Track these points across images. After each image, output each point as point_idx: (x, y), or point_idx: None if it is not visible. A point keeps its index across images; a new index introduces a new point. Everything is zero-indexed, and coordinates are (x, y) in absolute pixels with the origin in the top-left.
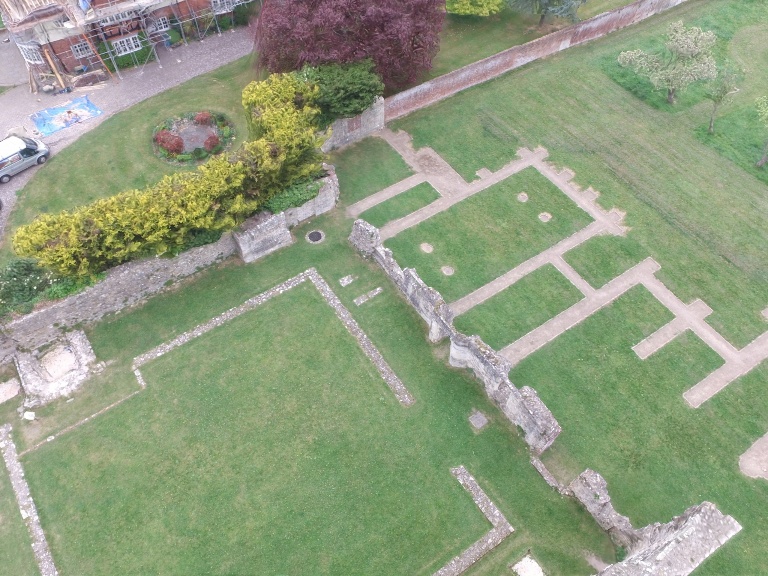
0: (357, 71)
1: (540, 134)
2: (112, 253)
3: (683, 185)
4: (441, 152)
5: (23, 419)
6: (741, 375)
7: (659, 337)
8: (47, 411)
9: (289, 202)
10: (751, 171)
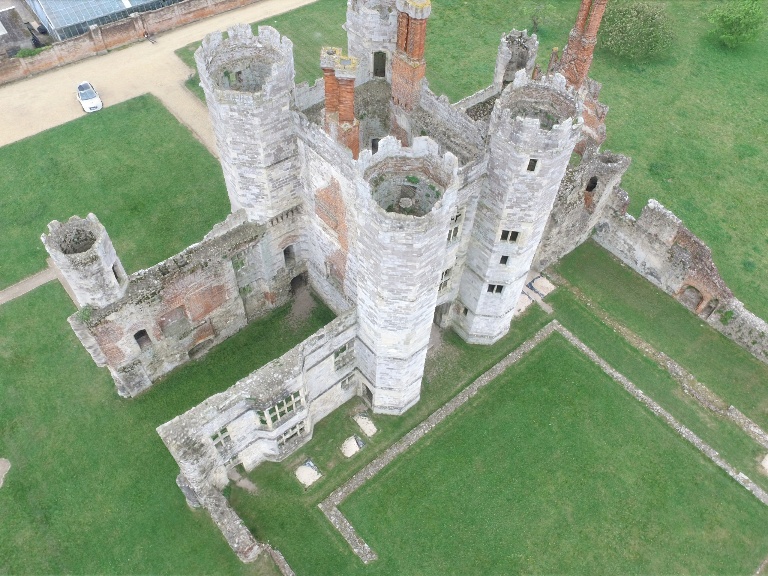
0: None
1: None
2: None
3: None
4: None
5: None
6: None
7: None
8: None
9: None
10: None
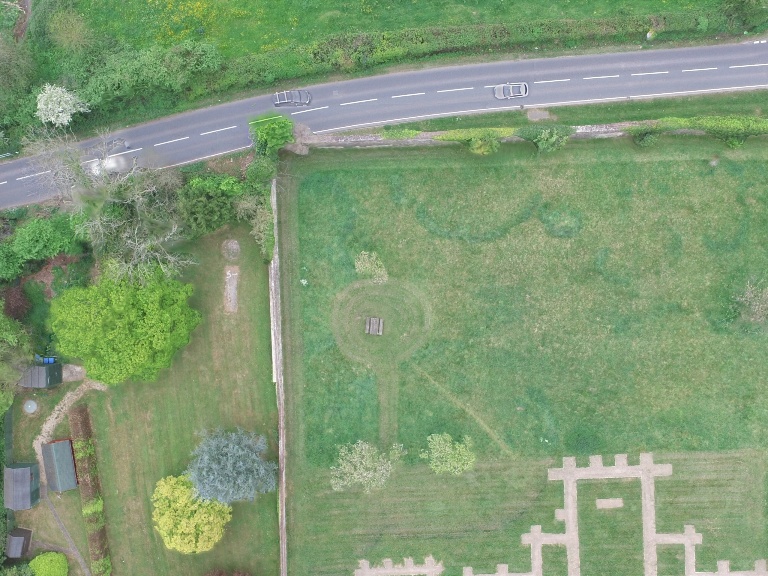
0: None
1: (350, 553)
2: None
3: (433, 507)
4: None
5: None
6: None
7: None
8: None
9: None
10: None
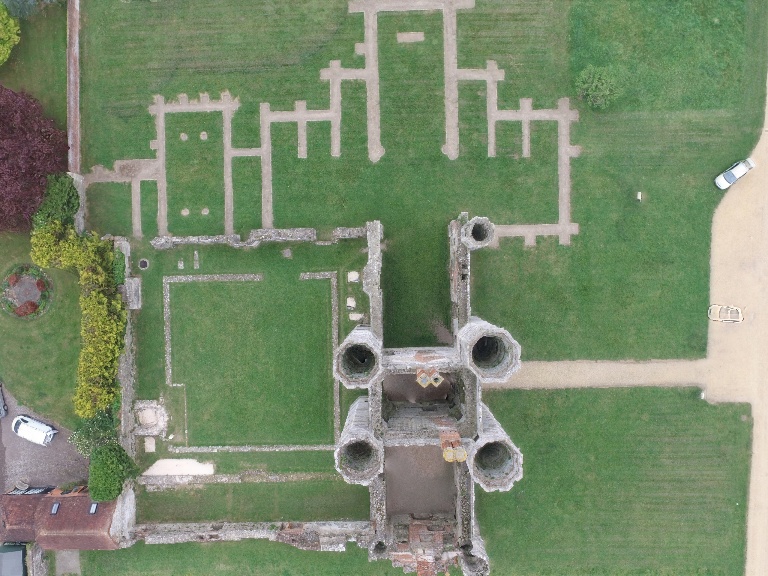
0: (54, 189)
1: (145, 88)
2: (113, 375)
3: (230, 40)
4: (124, 157)
5: (170, 440)
6: (341, 121)
7: (302, 140)
8: (172, 429)
9: (122, 273)
10: None
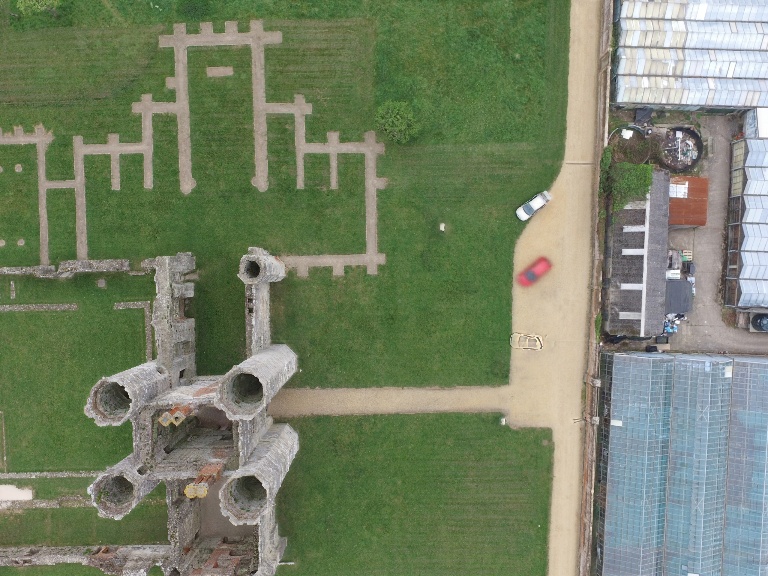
0: None
1: None
2: None
3: (43, 74)
4: None
5: None
6: (153, 153)
7: (115, 172)
8: None
9: None
10: (57, 25)
